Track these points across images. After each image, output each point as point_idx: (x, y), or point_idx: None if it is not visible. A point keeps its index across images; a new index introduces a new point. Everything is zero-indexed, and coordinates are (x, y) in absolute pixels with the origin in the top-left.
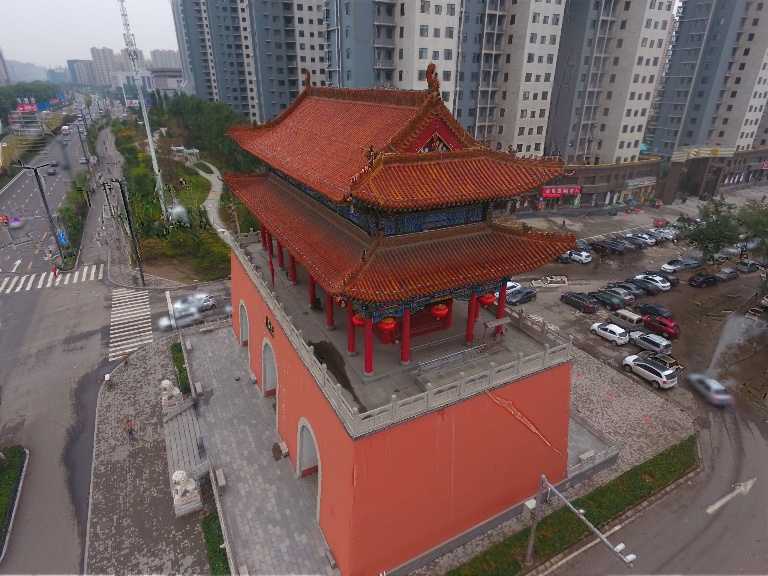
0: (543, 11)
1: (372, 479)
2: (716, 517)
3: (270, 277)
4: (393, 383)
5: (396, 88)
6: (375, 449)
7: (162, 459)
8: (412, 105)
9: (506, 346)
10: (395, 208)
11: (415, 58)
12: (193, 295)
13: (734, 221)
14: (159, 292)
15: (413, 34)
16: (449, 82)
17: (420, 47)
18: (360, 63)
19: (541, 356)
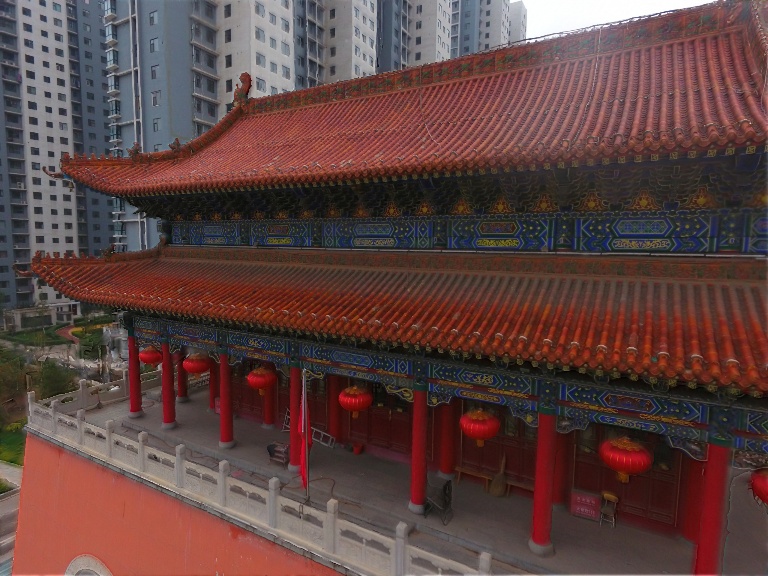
0: None
1: None
2: None
3: None
4: None
5: (592, 27)
6: None
7: None
8: (667, 39)
9: None
10: None
11: None
12: None
13: None
14: None
15: None
16: None
17: None
18: None
19: None
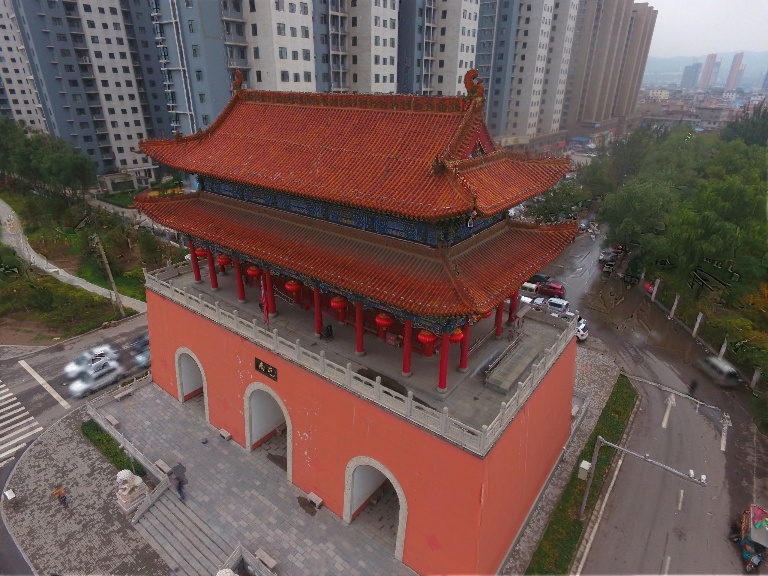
0: (382, 15)
1: (490, 492)
2: (670, 429)
3: (233, 313)
4: (465, 392)
5: None
6: (493, 461)
7: (161, 568)
8: (441, 111)
9: (522, 332)
10: (487, 216)
11: (276, 58)
12: (65, 357)
13: (566, 196)
14: (8, 364)
15: (270, 32)
16: (310, 83)
17: (279, 46)
18: (212, 62)
19: (565, 334)
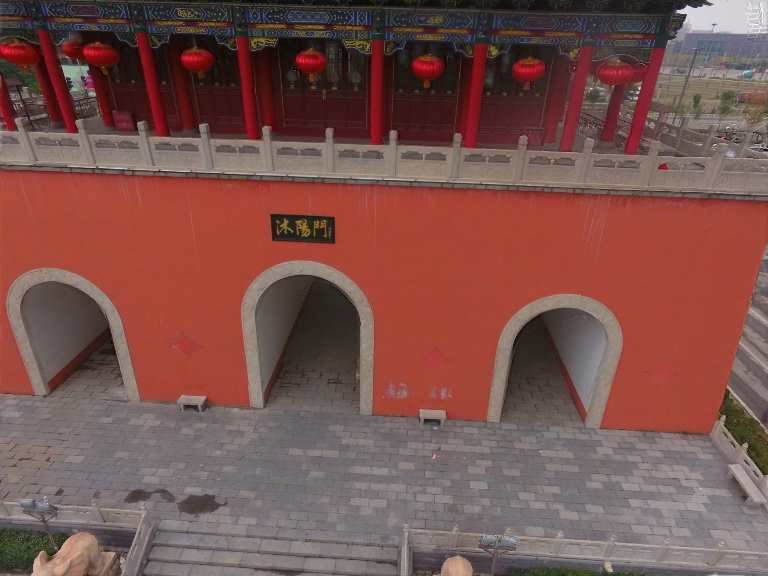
0: None
1: None
2: None
3: None
4: None
5: None
6: None
7: None
8: None
9: None
10: None
11: None
12: None
13: None
14: None
15: None
16: None
17: None
18: None
19: None
